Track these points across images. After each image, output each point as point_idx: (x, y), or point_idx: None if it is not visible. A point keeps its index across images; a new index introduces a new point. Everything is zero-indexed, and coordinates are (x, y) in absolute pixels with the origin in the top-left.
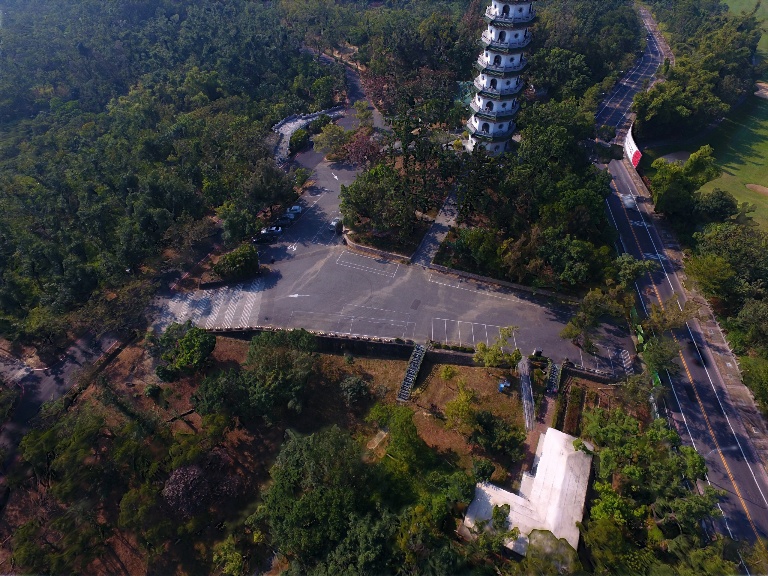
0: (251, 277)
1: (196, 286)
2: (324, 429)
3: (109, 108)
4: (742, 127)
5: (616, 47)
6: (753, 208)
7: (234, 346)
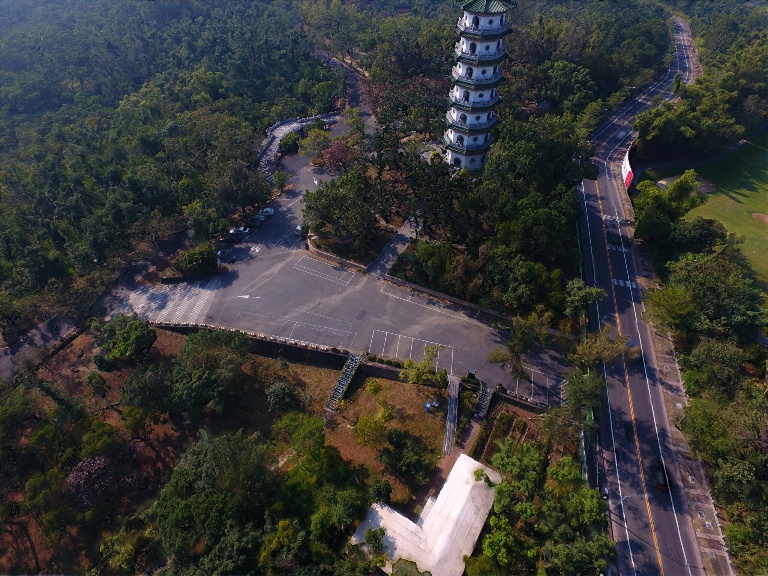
0: (210, 275)
1: (159, 280)
2: (249, 432)
3: (121, 104)
4: (764, 151)
5: (633, 62)
6: (742, 239)
7: (179, 341)
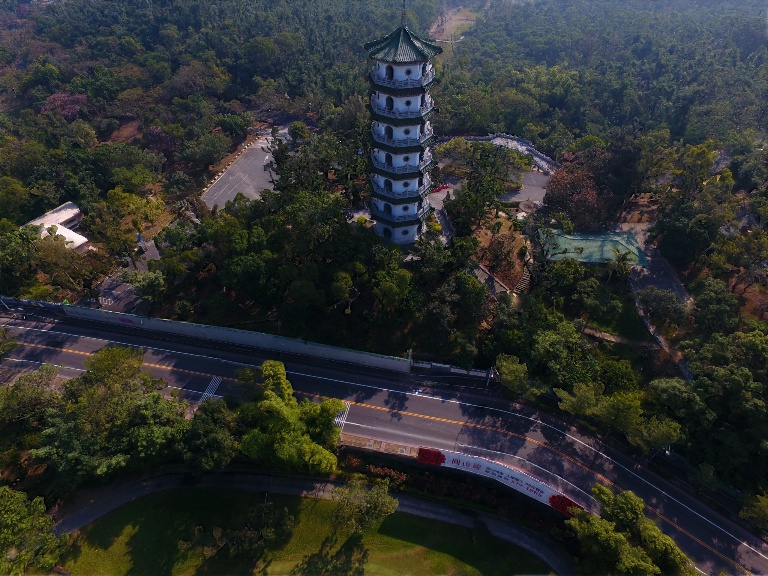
0: None
1: None
2: None
3: None
4: None
5: None
6: None
7: None
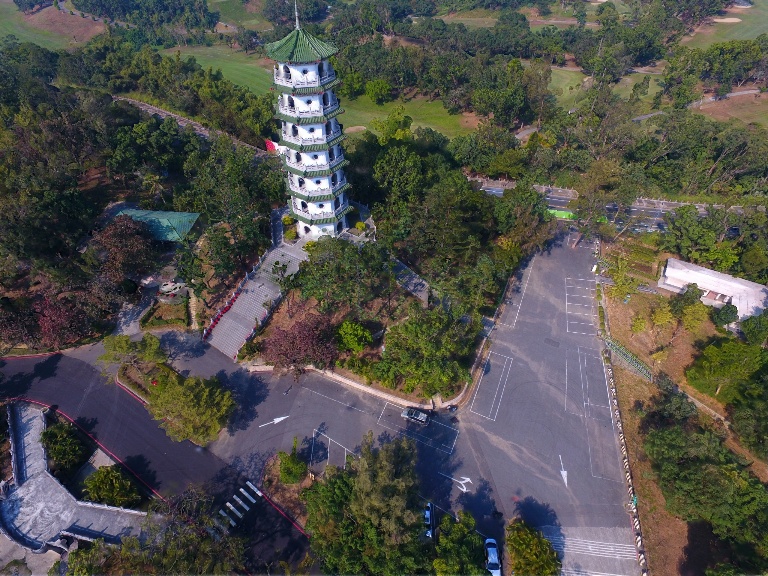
0: None
1: None
2: None
3: None
4: None
5: None
6: None
7: (659, 571)
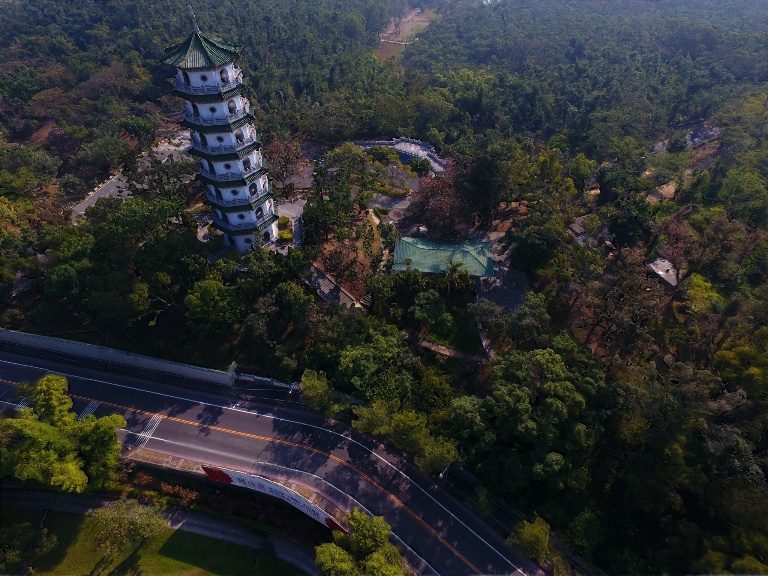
0: None
1: None
2: None
3: None
4: None
5: None
6: None
7: None
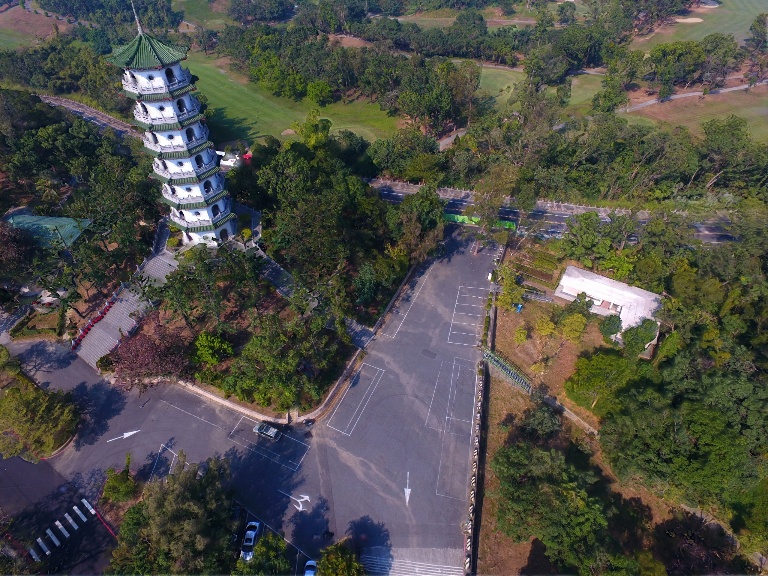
0: None
1: None
2: None
3: None
4: None
5: None
6: None
7: None
